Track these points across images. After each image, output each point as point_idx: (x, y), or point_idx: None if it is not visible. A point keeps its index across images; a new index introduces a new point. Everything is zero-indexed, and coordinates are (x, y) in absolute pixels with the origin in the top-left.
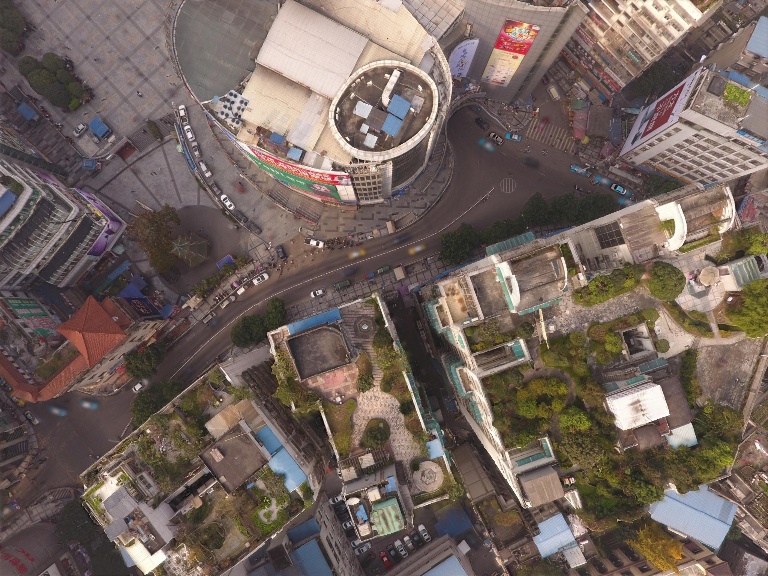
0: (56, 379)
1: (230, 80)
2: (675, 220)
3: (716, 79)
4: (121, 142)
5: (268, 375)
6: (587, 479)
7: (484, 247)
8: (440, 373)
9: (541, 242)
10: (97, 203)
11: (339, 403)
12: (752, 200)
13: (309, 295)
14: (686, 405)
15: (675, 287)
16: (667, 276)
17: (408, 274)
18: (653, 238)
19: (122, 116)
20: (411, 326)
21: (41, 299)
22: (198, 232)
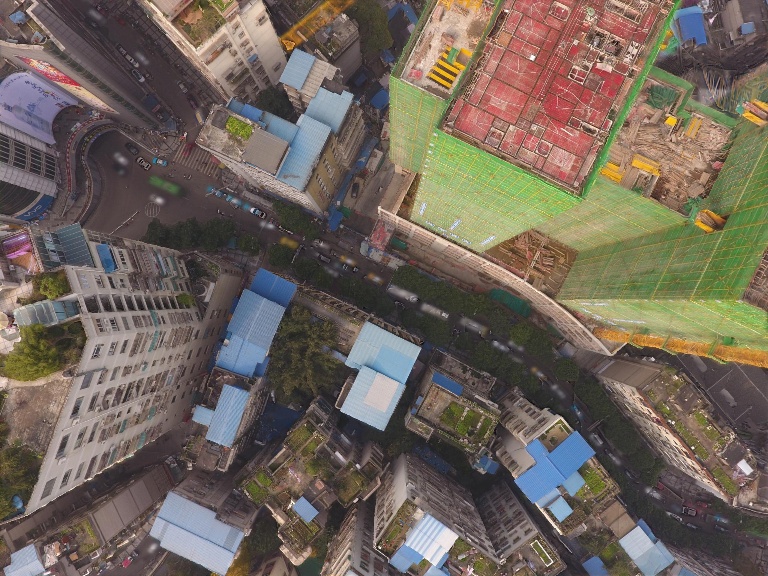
0: None
1: None
2: None
3: (218, 113)
4: None
5: None
6: None
7: None
8: None
9: None
10: None
11: None
12: (383, 223)
13: None
14: None
15: None
16: None
17: None
18: None
19: None
20: None
21: None
22: None
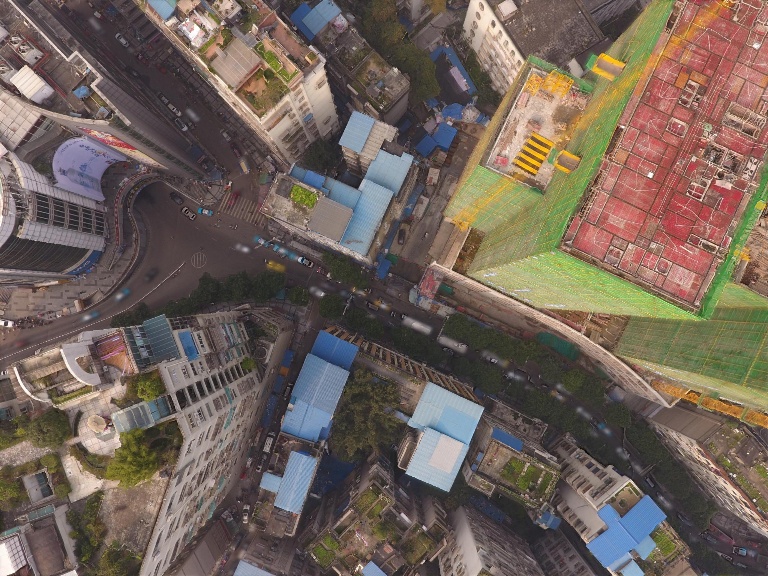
0: None
1: None
2: None
3: (282, 182)
4: None
5: None
6: None
7: None
8: None
9: None
10: None
11: None
12: (432, 272)
13: None
14: (55, 556)
15: (37, 442)
16: (29, 432)
17: None
18: None
19: None
20: None
21: None
22: None
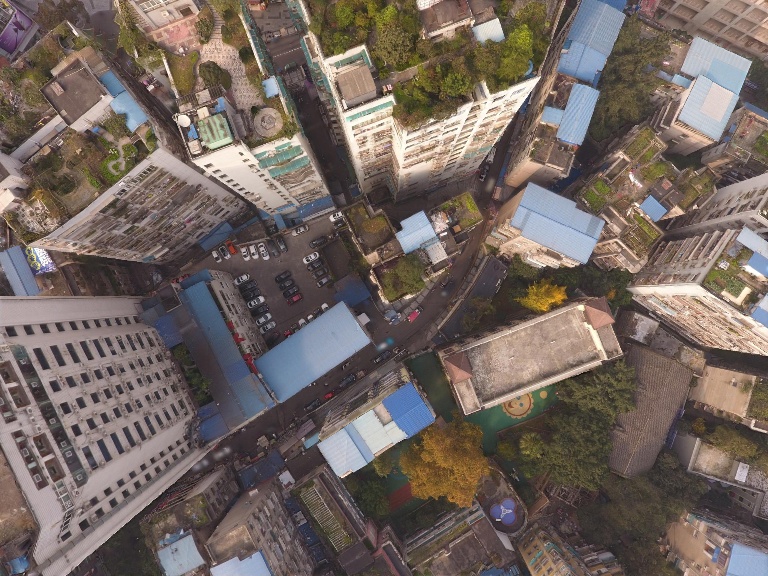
0: None
1: None
2: None
3: None
4: None
5: (139, 85)
6: (406, 90)
7: None
8: (344, 161)
9: None
10: None
11: (182, 55)
12: None
13: None
14: None
15: None
16: None
17: None
18: None
19: None
20: (318, 121)
21: None
22: None
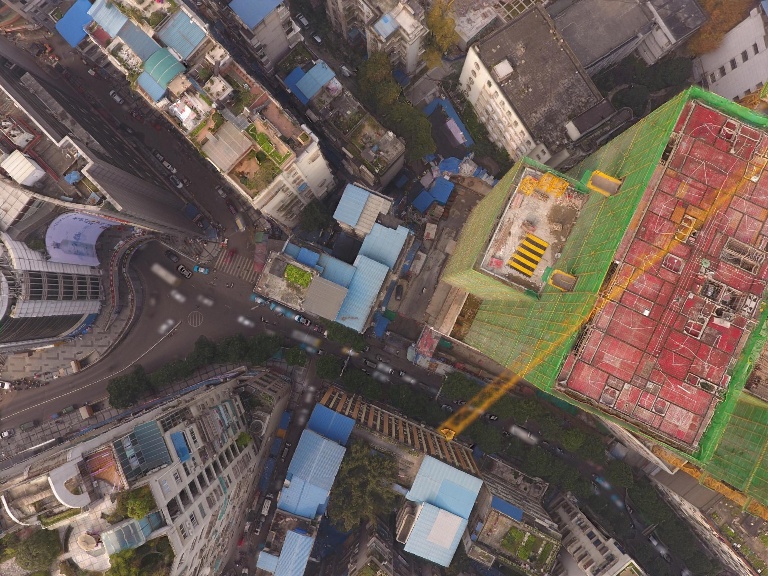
0: None
1: None
2: None
3: (276, 261)
4: None
5: None
6: None
7: None
8: None
9: None
10: None
11: None
12: (430, 330)
13: None
14: None
15: (26, 567)
16: None
17: (94, 413)
18: None
19: None
20: None
21: None
22: None
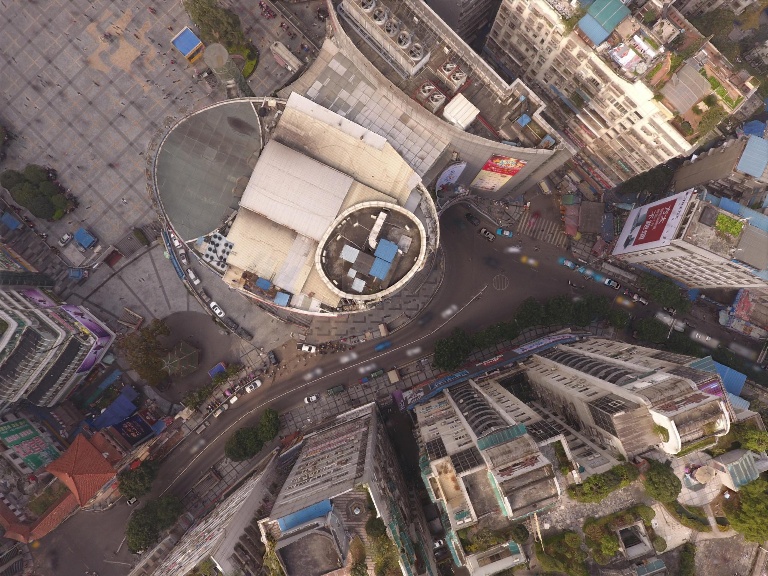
0: (48, 518)
1: (214, 218)
2: (669, 431)
3: (707, 210)
4: (107, 251)
5: None
6: None
7: (478, 347)
8: None
9: (533, 446)
10: (85, 318)
11: None
12: (747, 293)
13: (303, 401)
14: None
15: (671, 497)
16: (662, 486)
17: (402, 377)
18: (647, 439)
19: (107, 224)
20: (407, 430)
21: (31, 416)
22: (188, 338)
